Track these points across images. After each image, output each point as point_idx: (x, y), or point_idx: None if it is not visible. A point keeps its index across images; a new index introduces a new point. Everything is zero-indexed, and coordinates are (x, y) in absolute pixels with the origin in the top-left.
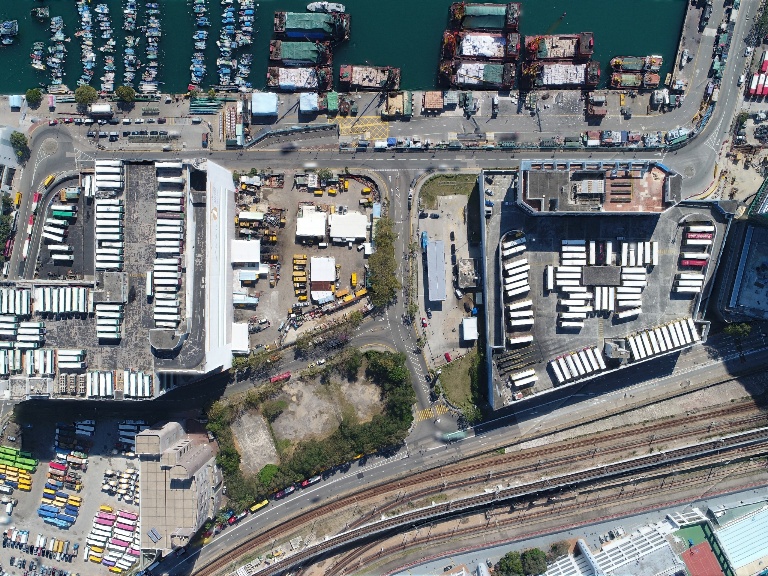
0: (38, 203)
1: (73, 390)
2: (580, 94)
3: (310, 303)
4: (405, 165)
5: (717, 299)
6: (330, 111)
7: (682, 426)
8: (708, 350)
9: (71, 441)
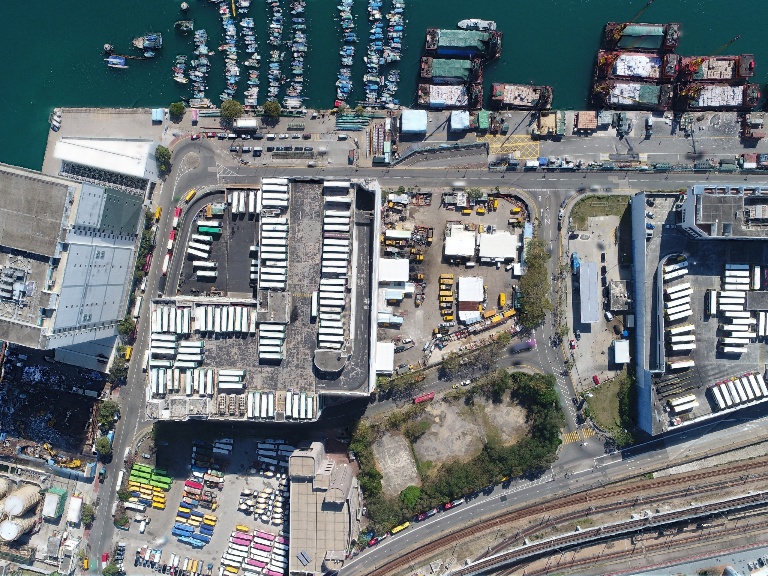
0: (179, 218)
1: (233, 411)
2: (736, 116)
3: (456, 323)
4: (556, 185)
5: None
6: (480, 129)
7: None
8: None
9: (208, 459)
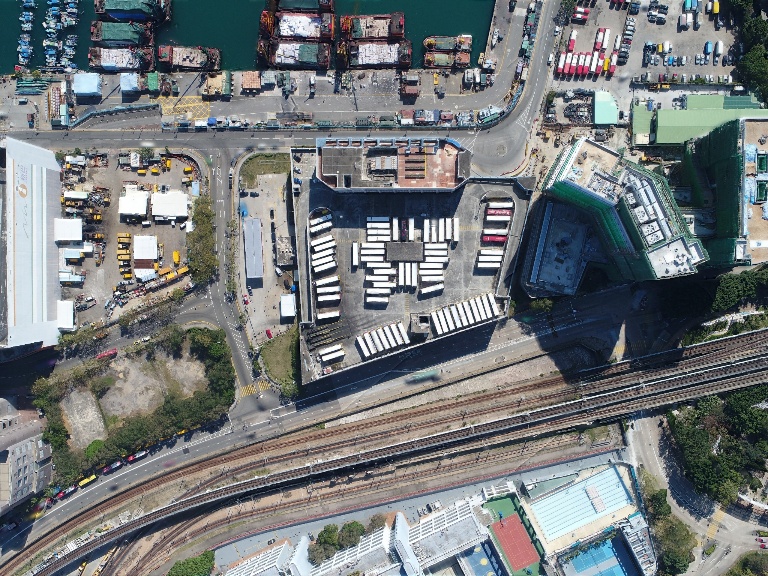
0: None
1: None
2: (395, 74)
3: (135, 281)
4: (226, 144)
5: (521, 275)
6: (152, 91)
7: (493, 400)
8: (521, 326)
9: None
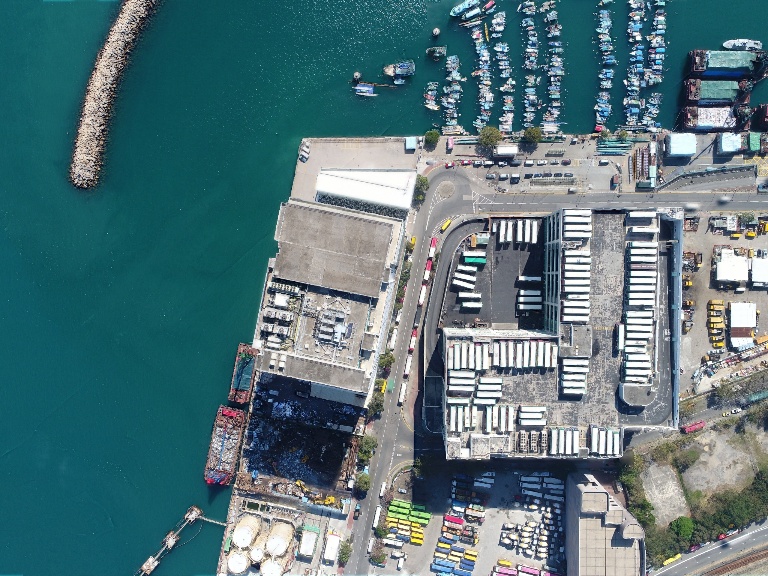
0: (435, 248)
1: (535, 448)
2: None
3: (726, 350)
4: None
5: None
6: (749, 152)
7: None
8: None
9: (469, 494)
